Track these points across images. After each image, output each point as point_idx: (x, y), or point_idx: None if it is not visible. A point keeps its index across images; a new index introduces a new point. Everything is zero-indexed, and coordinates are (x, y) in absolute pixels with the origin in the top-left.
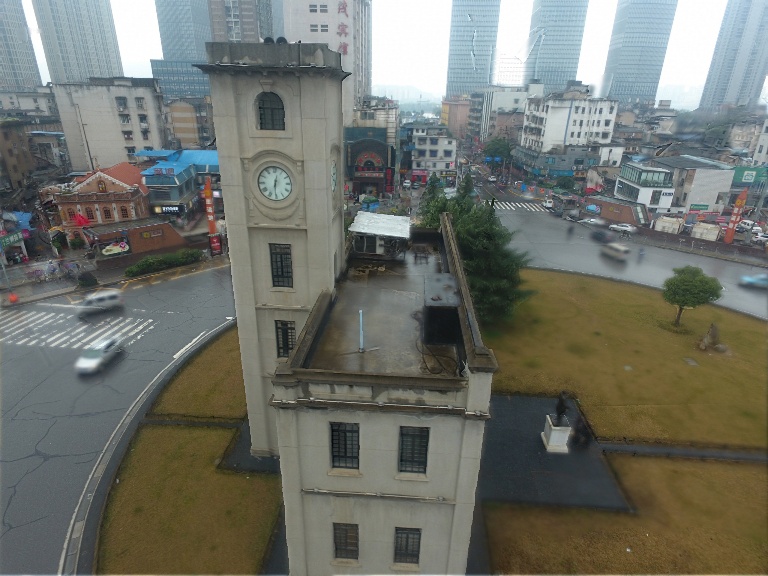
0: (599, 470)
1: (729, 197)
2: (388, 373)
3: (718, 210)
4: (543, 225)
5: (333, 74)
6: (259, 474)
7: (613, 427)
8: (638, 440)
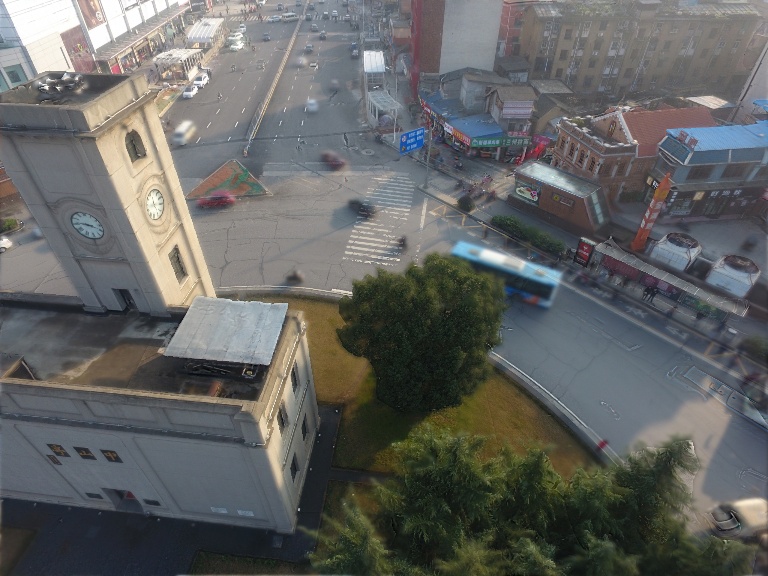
0: None
1: None
2: None
3: None
4: None
5: (4, 134)
6: None
7: None
8: None
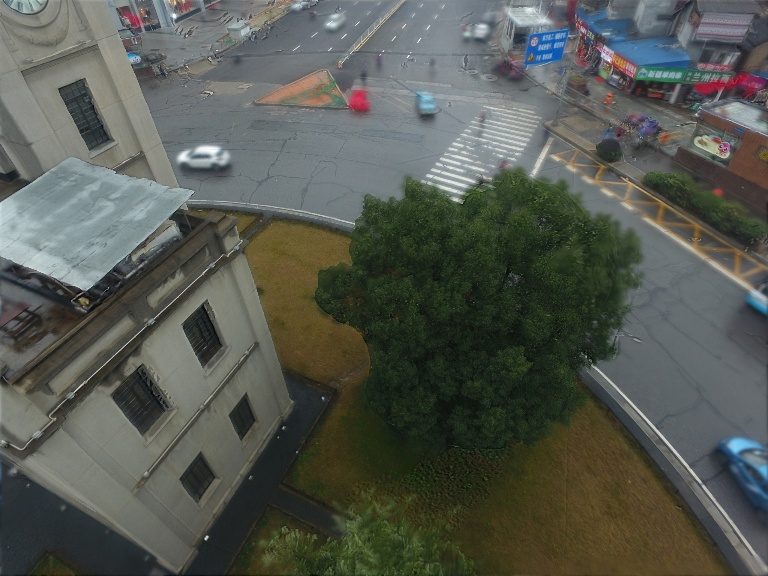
0: None
1: None
2: None
3: None
4: None
5: None
6: None
7: None
8: None
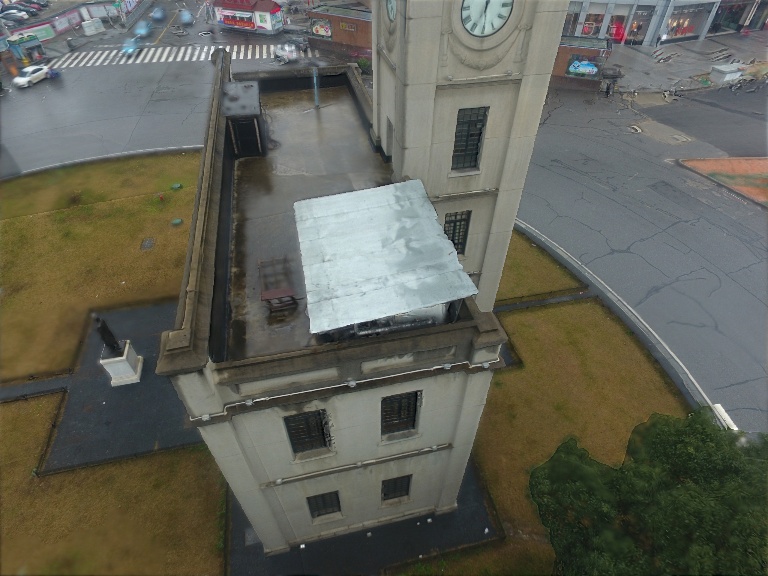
0: (95, 349)
1: None
2: None
3: None
4: None
5: None
6: None
7: (22, 420)
8: (4, 405)
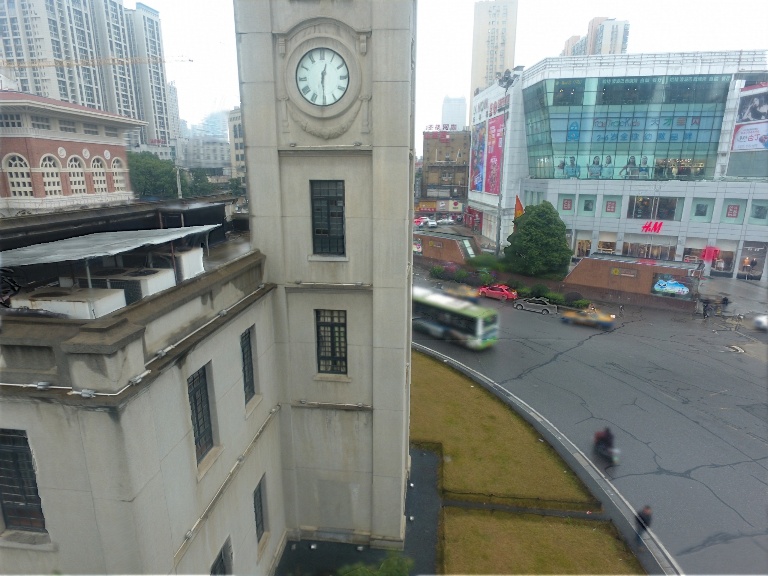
0: None
1: None
2: None
3: None
4: None
5: None
6: None
7: None
8: None
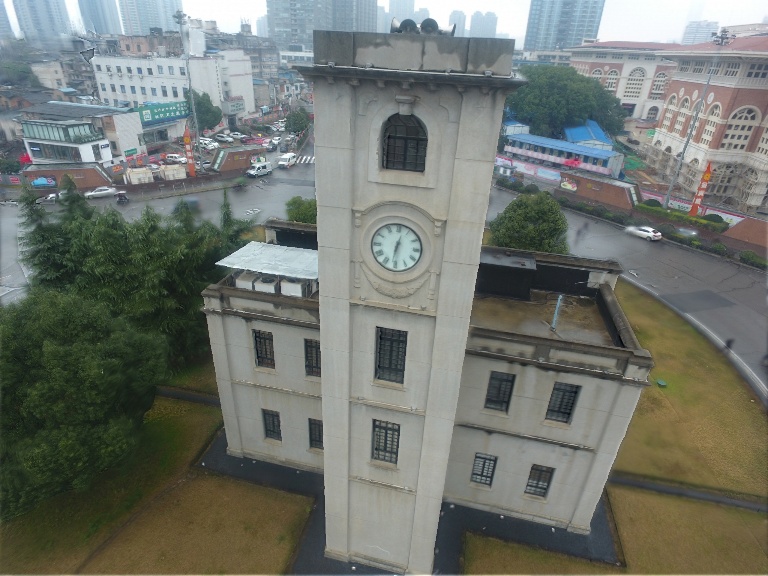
0: None
1: (142, 137)
2: (619, 308)
3: (144, 151)
4: (14, 221)
5: None
6: (465, 568)
7: None
8: None
